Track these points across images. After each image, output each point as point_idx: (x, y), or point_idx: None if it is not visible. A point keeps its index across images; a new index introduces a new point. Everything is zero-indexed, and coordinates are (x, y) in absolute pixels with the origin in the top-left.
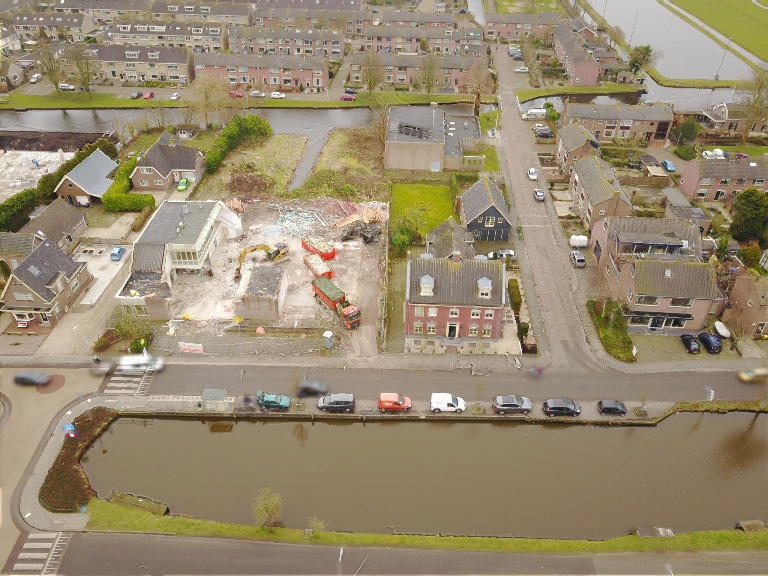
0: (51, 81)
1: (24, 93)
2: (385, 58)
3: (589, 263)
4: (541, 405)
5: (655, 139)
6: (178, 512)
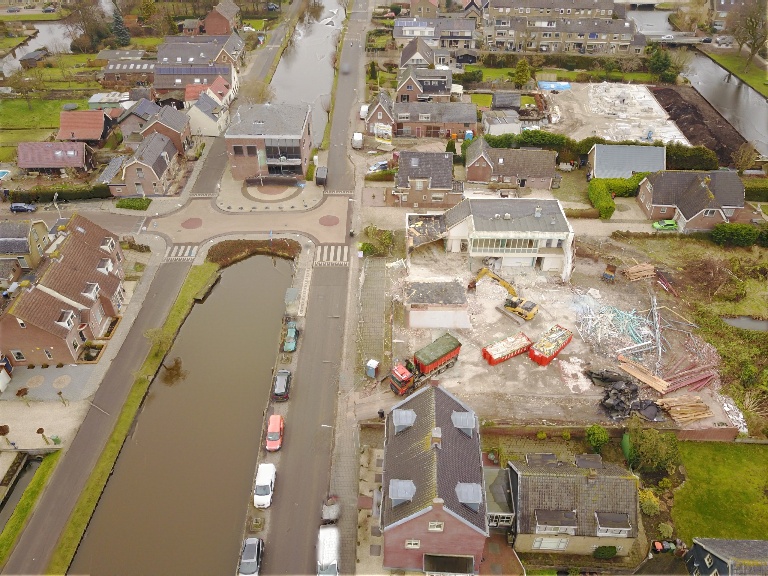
0: None
1: None
2: None
3: None
4: None
5: None
6: (200, 308)
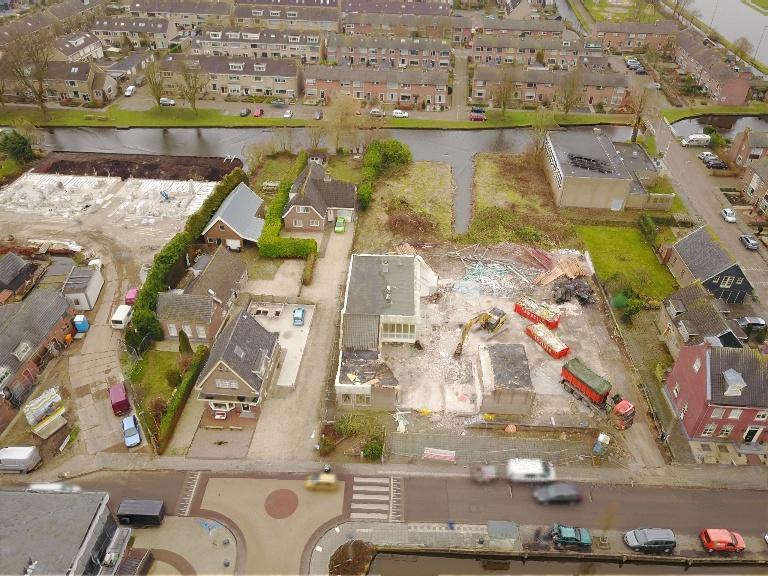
0: (154, 96)
1: (121, 108)
2: None
3: None
4: None
5: None
6: None
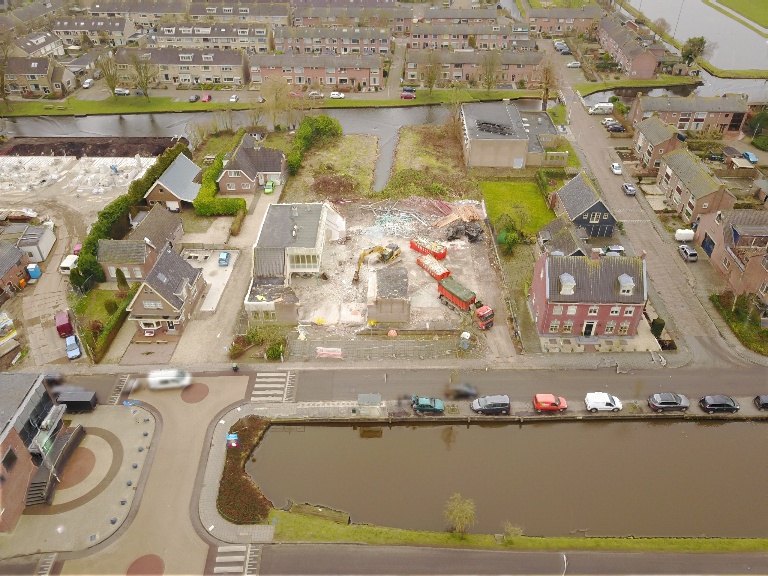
0: (108, 86)
1: (80, 99)
2: (441, 55)
3: (700, 257)
4: (697, 402)
5: (729, 131)
6: (358, 521)
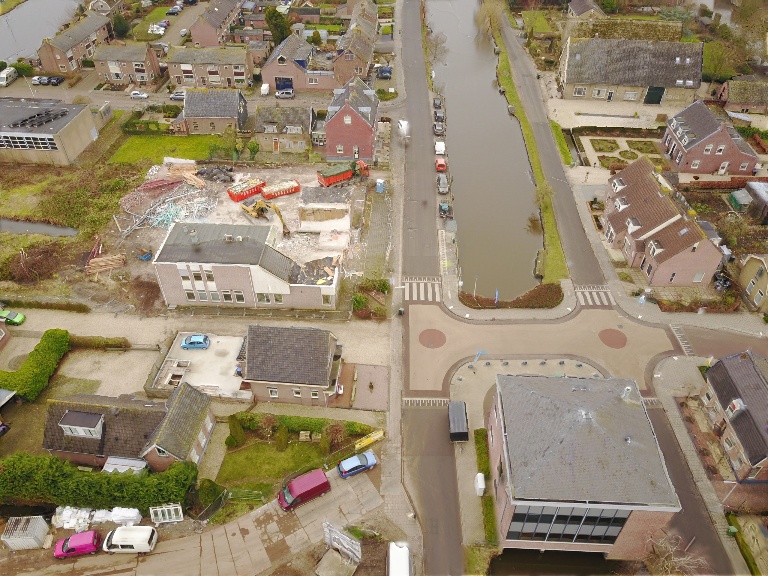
0: None
1: None
2: None
3: None
4: None
5: (111, 41)
6: None
